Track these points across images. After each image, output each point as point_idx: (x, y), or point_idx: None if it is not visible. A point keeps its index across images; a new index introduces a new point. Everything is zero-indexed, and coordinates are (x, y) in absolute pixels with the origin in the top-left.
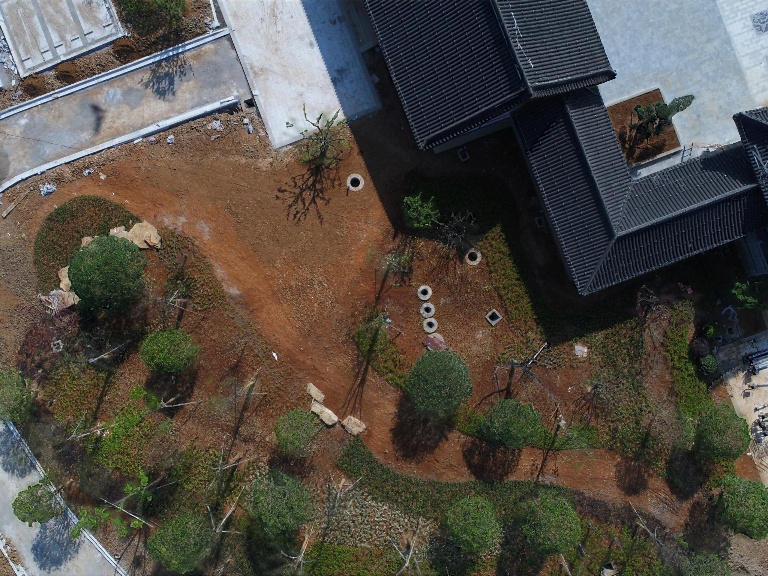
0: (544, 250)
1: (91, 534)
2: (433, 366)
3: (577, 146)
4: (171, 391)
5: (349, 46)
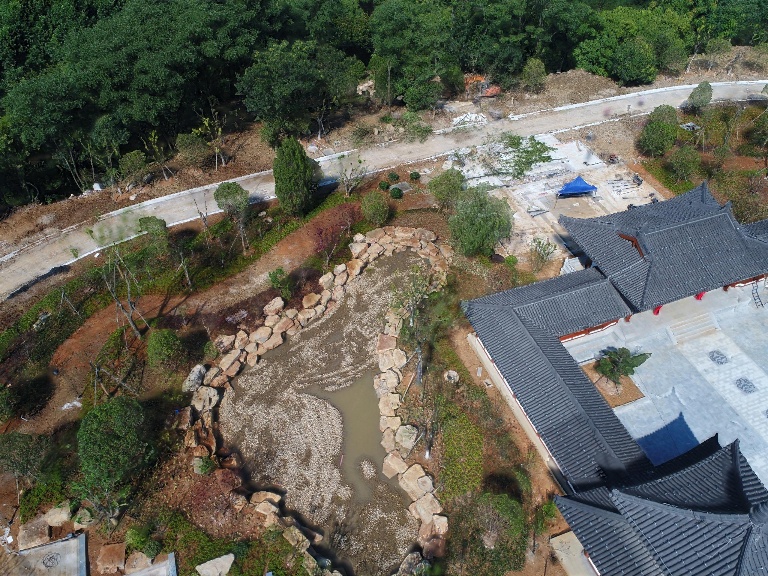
0: None
1: None
2: None
3: None
4: None
5: None
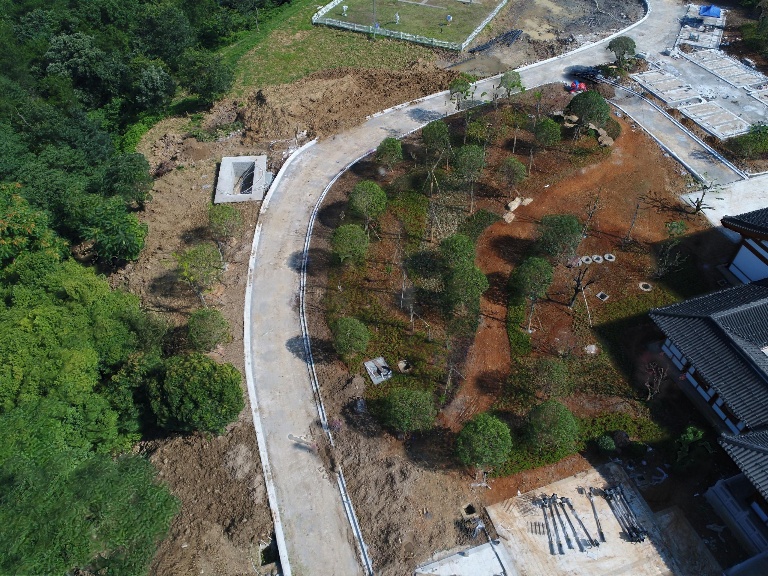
0: None
1: None
2: (574, 219)
3: None
4: (516, 147)
5: None
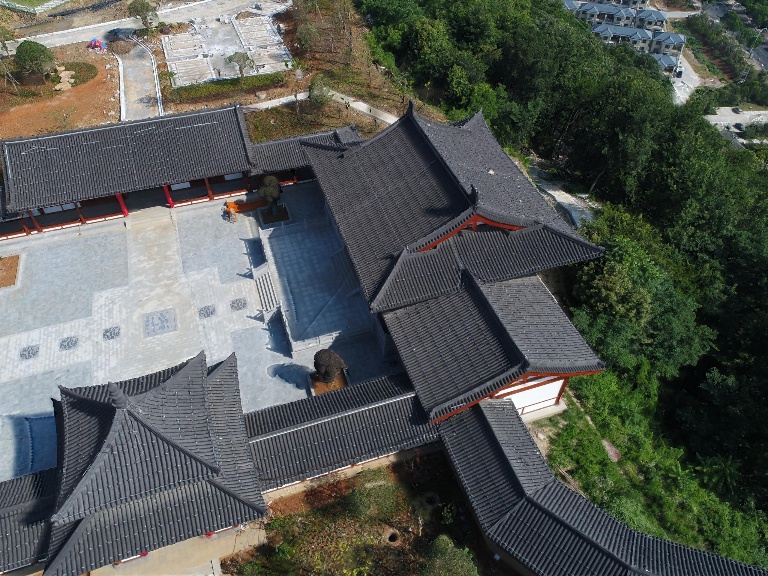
0: None
1: None
2: None
3: None
4: None
5: None
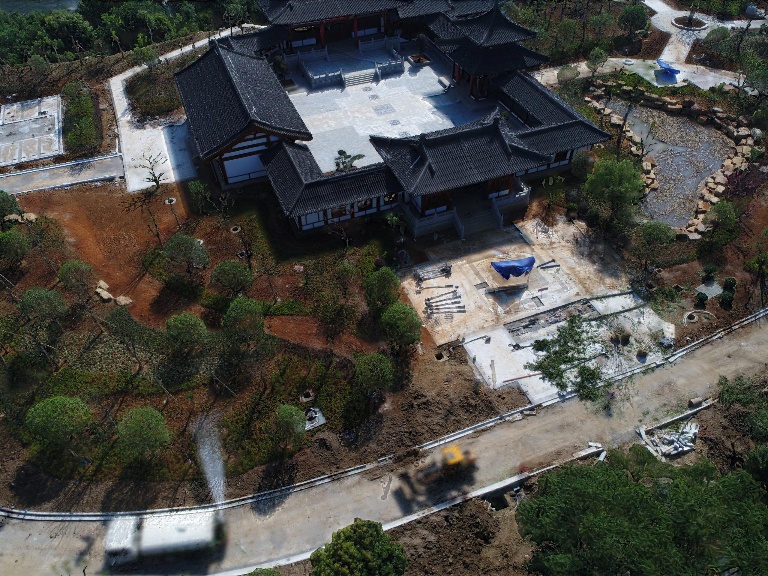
0: (282, 227)
1: None
2: None
3: (288, 157)
4: (0, 285)
5: (186, 158)
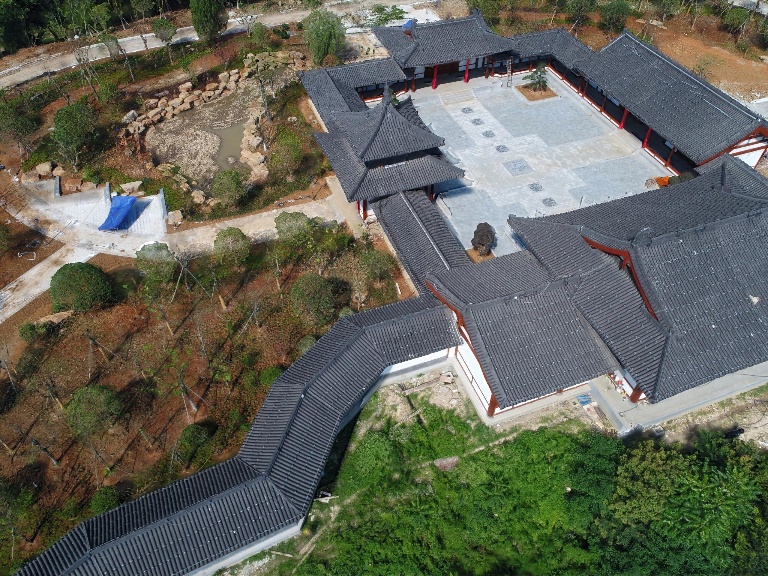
0: None
1: (736, 5)
2: (624, 6)
3: None
4: None
5: None
